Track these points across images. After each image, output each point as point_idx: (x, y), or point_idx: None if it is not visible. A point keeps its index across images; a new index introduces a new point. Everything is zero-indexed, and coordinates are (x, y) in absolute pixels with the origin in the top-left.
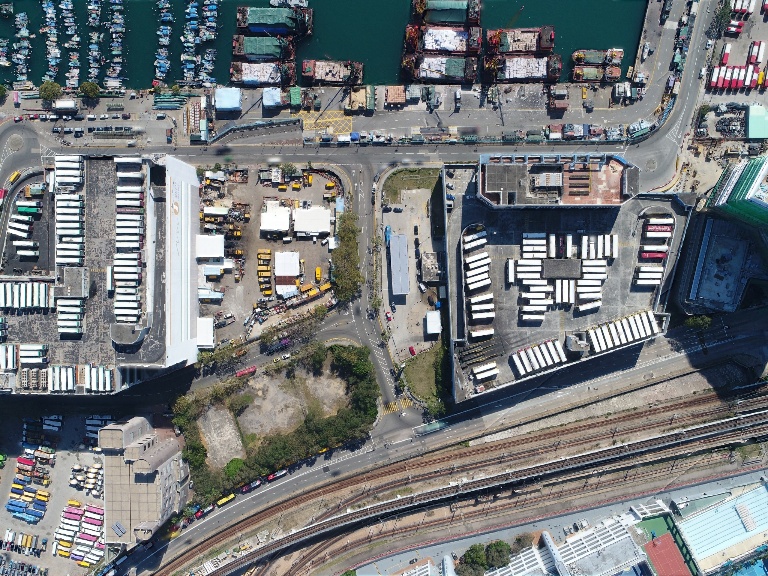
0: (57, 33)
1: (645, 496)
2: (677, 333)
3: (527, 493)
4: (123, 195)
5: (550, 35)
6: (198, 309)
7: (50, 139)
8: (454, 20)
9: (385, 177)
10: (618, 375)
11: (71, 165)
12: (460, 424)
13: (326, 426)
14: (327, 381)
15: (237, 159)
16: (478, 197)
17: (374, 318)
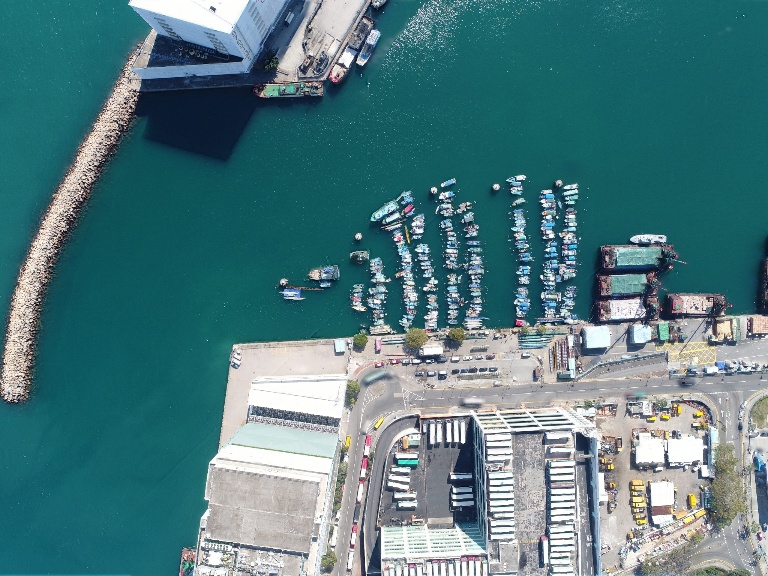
0: (414, 277)
1: None
2: None
3: None
4: (558, 471)
5: None
6: None
7: (413, 383)
8: None
9: (751, 403)
10: None
11: (503, 444)
12: None
13: None
14: None
15: (604, 393)
16: None
17: (745, 538)
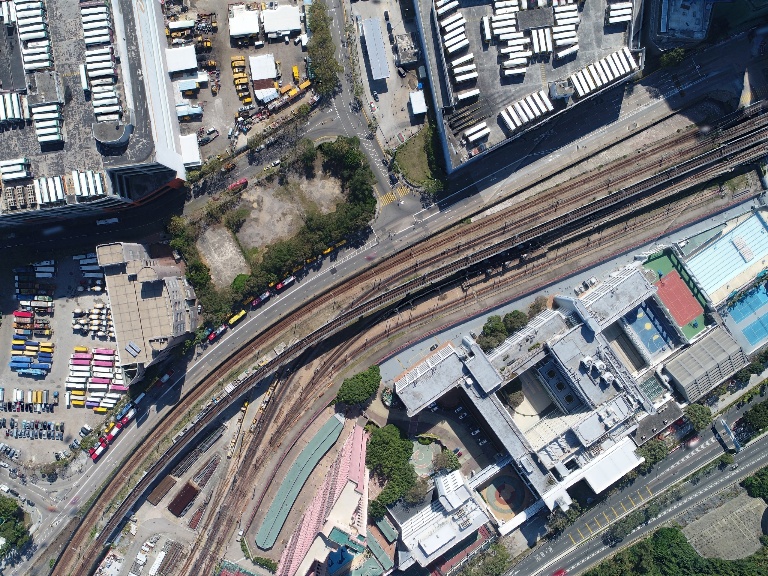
0: None
1: (646, 244)
2: (653, 80)
3: (534, 260)
4: None
5: None
6: (179, 128)
7: None
8: None
9: None
10: (604, 130)
11: None
12: (459, 203)
13: (327, 221)
14: (321, 182)
15: None
16: None
17: (358, 111)
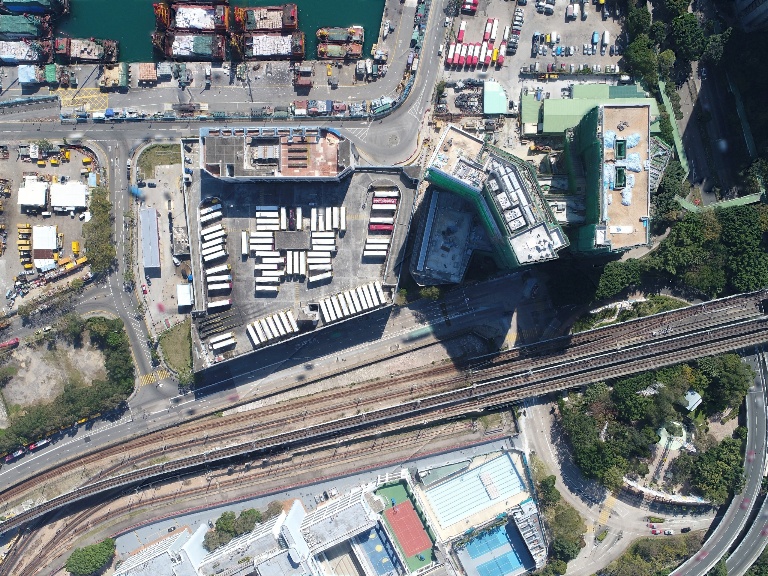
0: None
1: (392, 465)
2: (421, 305)
3: (279, 462)
4: None
5: (291, 13)
6: None
7: None
8: None
9: (139, 153)
10: (365, 346)
11: None
12: (215, 395)
13: (80, 396)
14: (87, 353)
15: None
16: None
17: (131, 291)
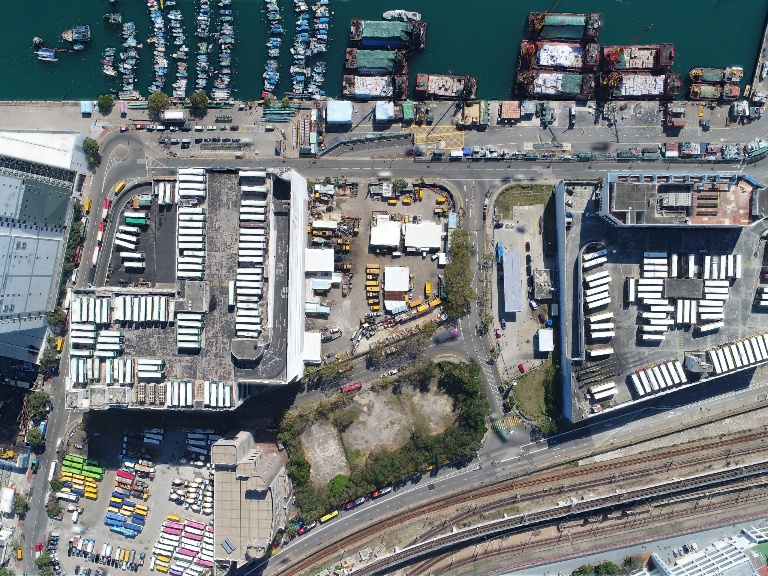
0: (165, 43)
1: (757, 518)
2: None
3: (636, 514)
4: (248, 209)
5: (670, 53)
6: (304, 323)
7: (156, 150)
8: (570, 36)
9: (497, 193)
10: (731, 396)
11: (195, 178)
12: (569, 443)
13: (435, 444)
14: (434, 398)
15: (346, 172)
16: (601, 215)
17: (483, 335)
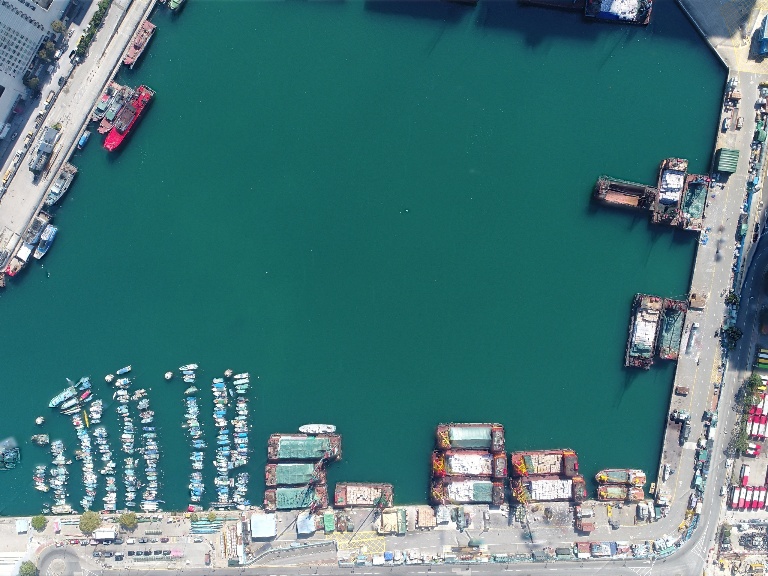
0: (93, 459)
1: None
2: None
3: None
4: None
5: (574, 465)
6: None
7: (91, 562)
8: (479, 446)
9: None
10: None
11: None
12: None
13: None
14: None
15: None
16: None
17: None
